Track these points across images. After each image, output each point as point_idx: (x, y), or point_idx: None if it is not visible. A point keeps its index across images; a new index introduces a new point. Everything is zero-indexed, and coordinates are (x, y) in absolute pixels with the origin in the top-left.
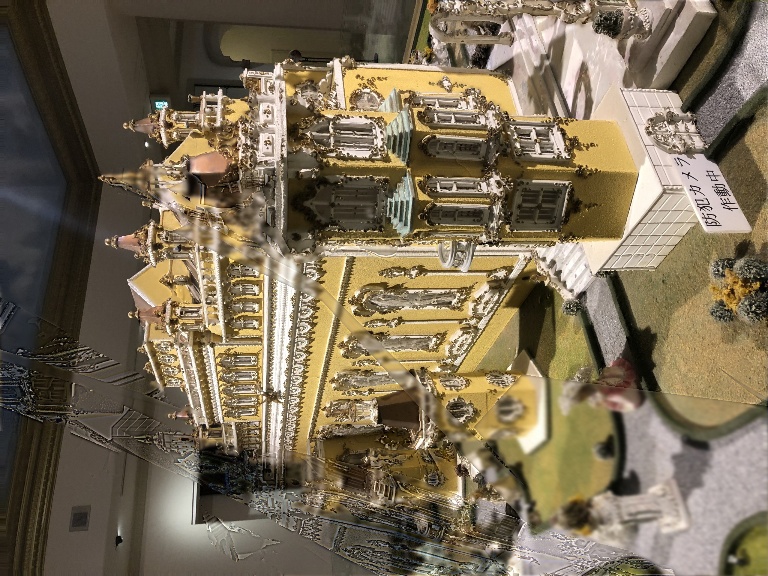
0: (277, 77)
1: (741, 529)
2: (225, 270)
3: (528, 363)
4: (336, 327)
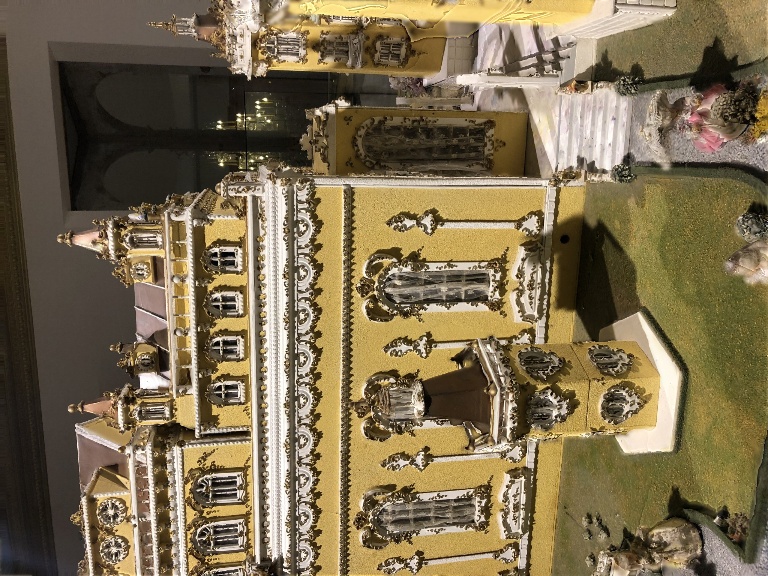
0: None
1: None
2: (200, 258)
3: (612, 330)
4: (348, 358)
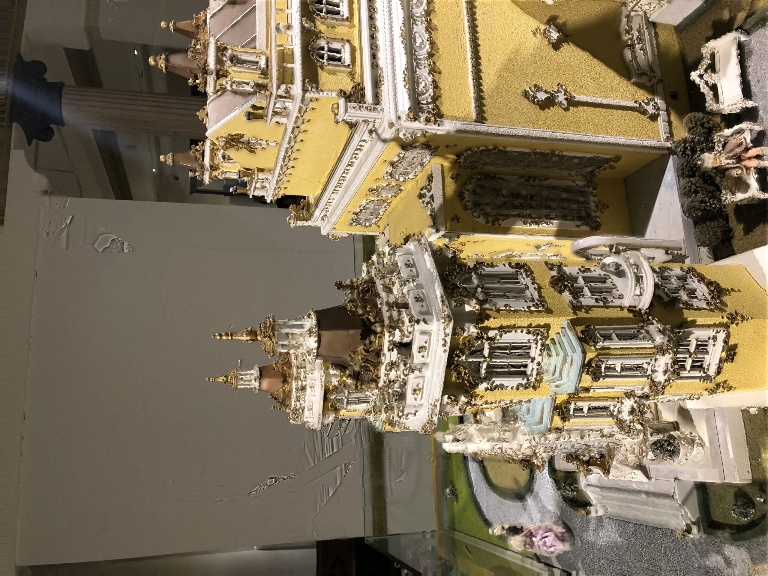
0: (383, 140)
1: (341, 527)
2: None
3: None
4: None
